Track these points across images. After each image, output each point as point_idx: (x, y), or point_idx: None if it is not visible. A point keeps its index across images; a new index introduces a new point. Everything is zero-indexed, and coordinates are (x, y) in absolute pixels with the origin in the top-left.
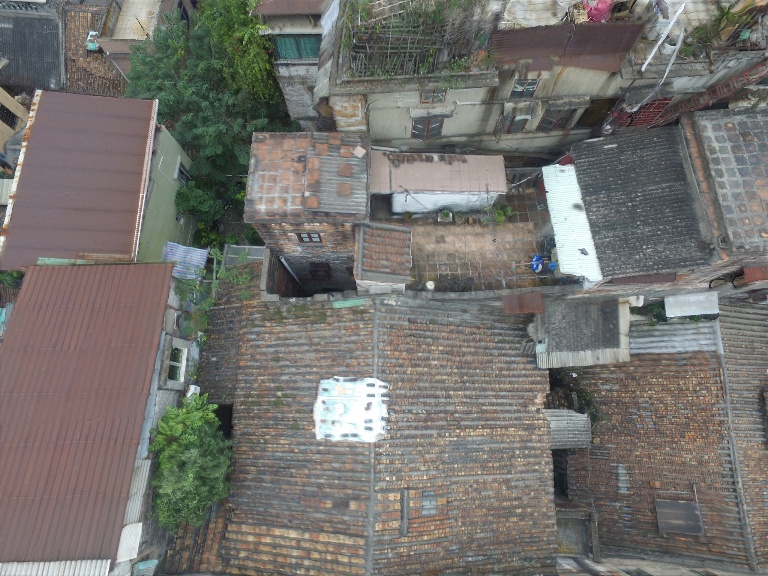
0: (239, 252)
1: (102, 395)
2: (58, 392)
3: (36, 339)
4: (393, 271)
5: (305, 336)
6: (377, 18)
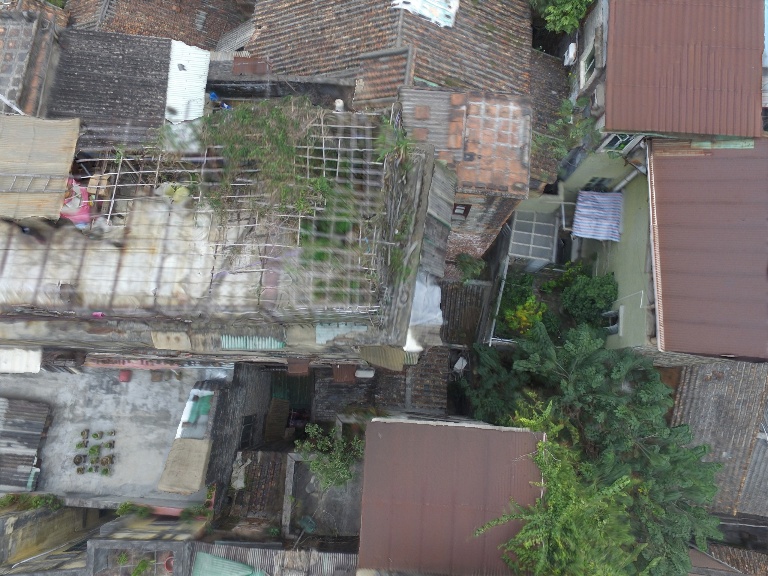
0: (539, 252)
1: (652, 1)
2: (694, 5)
3: (730, 57)
4: (377, 61)
5: (466, 72)
6: (369, 115)
